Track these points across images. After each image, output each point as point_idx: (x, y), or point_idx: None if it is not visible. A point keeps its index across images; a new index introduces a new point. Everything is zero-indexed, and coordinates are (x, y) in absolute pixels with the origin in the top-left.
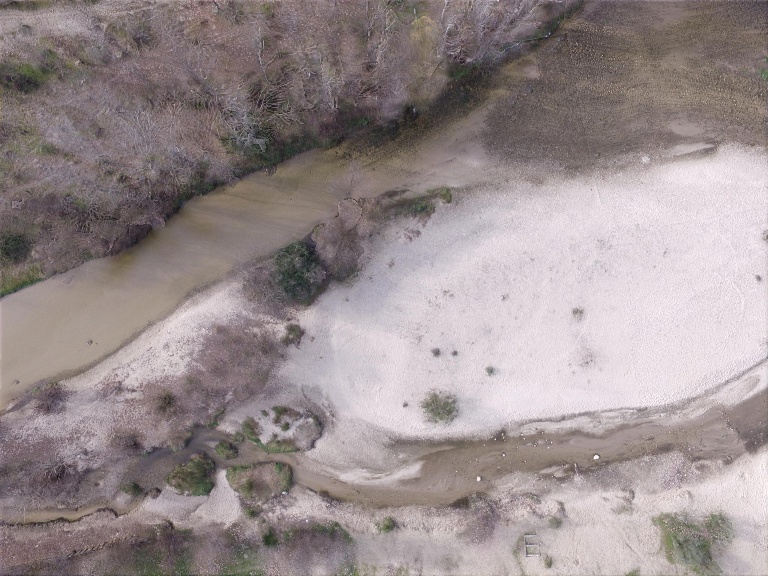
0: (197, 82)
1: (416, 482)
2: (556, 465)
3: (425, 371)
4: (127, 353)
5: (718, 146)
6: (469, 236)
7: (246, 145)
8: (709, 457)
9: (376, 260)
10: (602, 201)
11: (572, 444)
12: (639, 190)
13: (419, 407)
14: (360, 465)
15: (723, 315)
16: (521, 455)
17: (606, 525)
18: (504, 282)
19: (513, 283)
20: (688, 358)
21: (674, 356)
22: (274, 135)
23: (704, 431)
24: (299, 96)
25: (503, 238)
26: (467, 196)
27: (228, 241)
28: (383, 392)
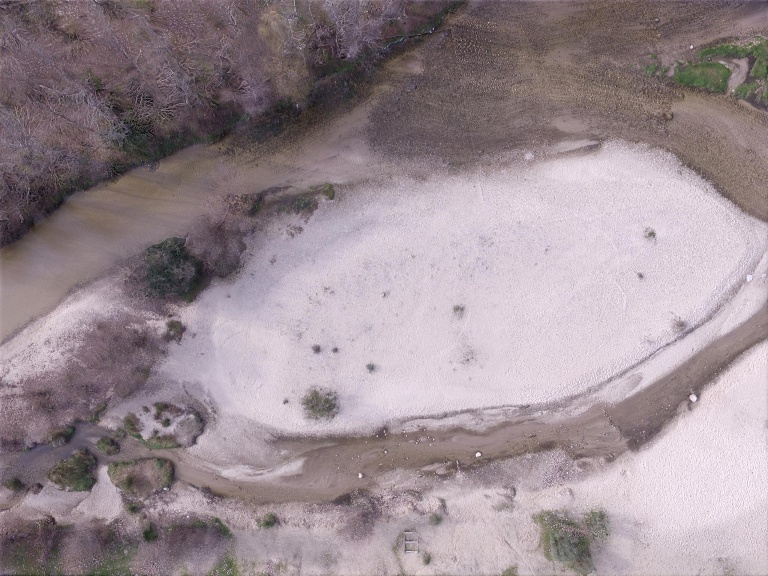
0: (76, 77)
1: (298, 479)
2: (438, 462)
3: (305, 368)
4: (9, 349)
5: (602, 143)
6: (351, 233)
7: (106, 141)
8: (591, 455)
9: (258, 257)
10: (485, 198)
11: (454, 441)
12: (522, 187)
13: (299, 404)
14: (242, 461)
15: (605, 313)
16: (403, 452)
17: (486, 522)
18: (385, 279)
19: (394, 280)
20: (569, 356)
21: (555, 354)
22: (154, 131)
23: (586, 429)
24: (153, 91)
25: (385, 235)
26: (350, 192)
27: (110, 237)
28: (264, 389)
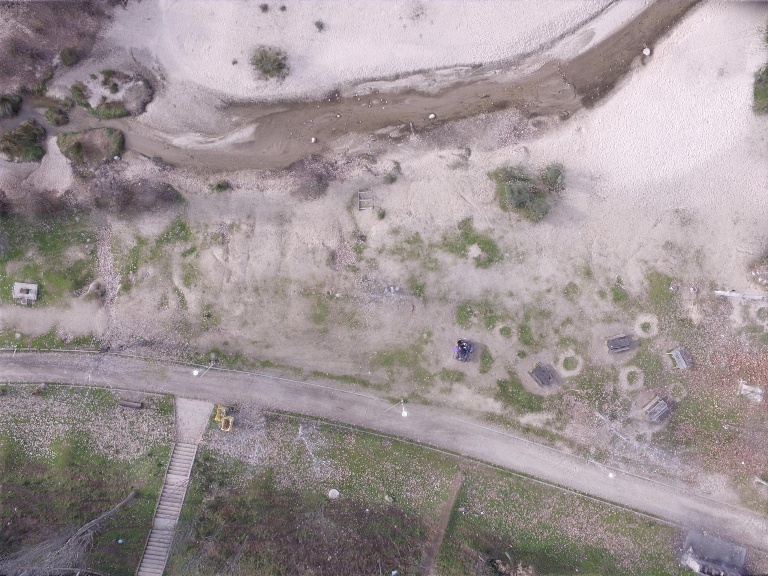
0: None
1: (250, 145)
2: (392, 125)
3: (254, 27)
4: None
5: None
6: None
7: None
8: (546, 113)
9: None
10: None
11: (407, 104)
12: None
13: (249, 64)
14: (193, 129)
15: None
16: (356, 116)
17: (441, 180)
18: None
19: None
20: (520, 9)
21: (506, 7)
22: None
23: (540, 87)
24: None
25: None
26: None
27: None
28: (212, 51)
